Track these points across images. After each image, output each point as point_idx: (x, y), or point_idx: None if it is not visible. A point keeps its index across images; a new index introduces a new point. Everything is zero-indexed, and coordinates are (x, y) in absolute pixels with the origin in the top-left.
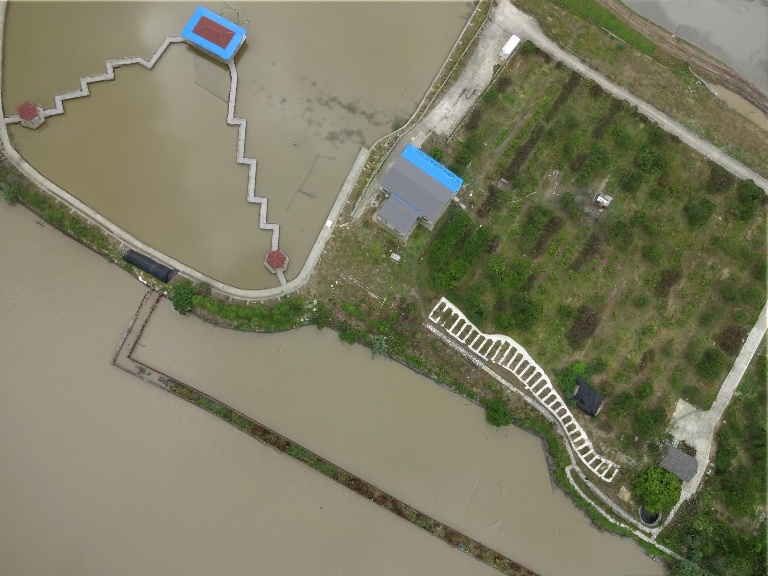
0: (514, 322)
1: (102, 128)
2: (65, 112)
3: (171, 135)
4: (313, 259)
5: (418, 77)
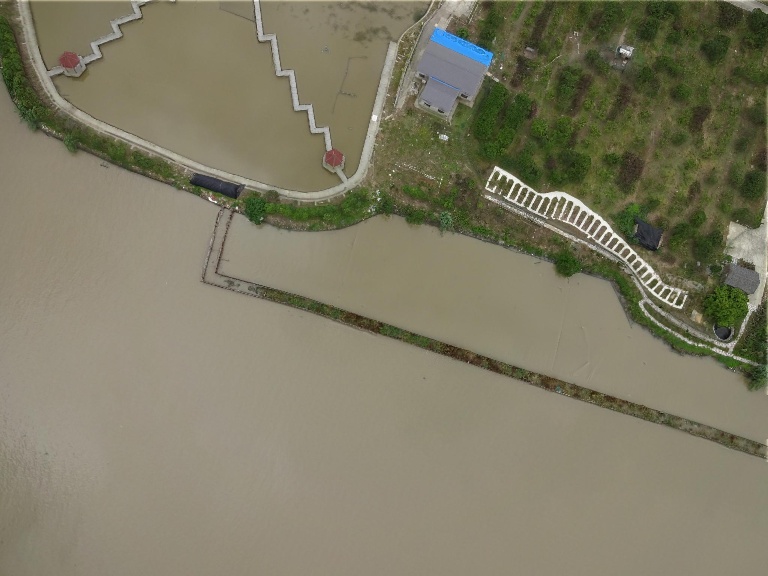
0: (567, 176)
1: (141, 66)
2: (103, 56)
3: (208, 61)
4: (367, 153)
5: None
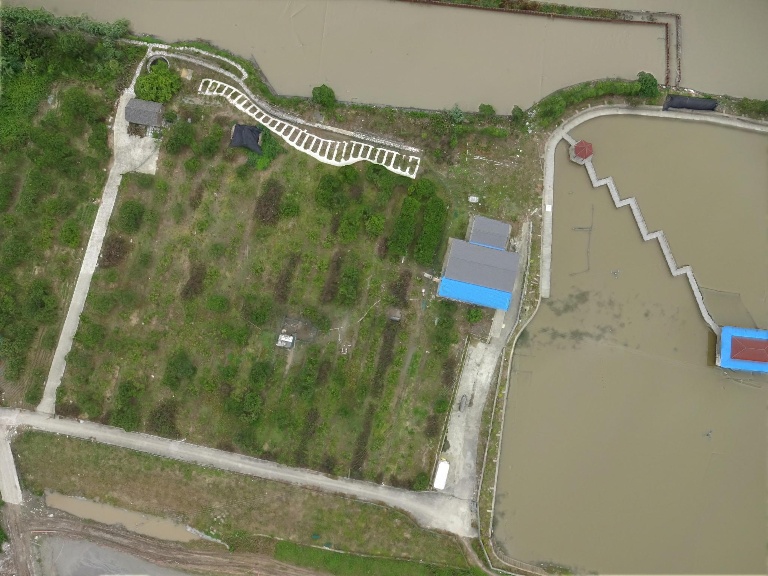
0: (340, 177)
1: None
2: None
3: (734, 233)
4: (549, 169)
5: (524, 402)
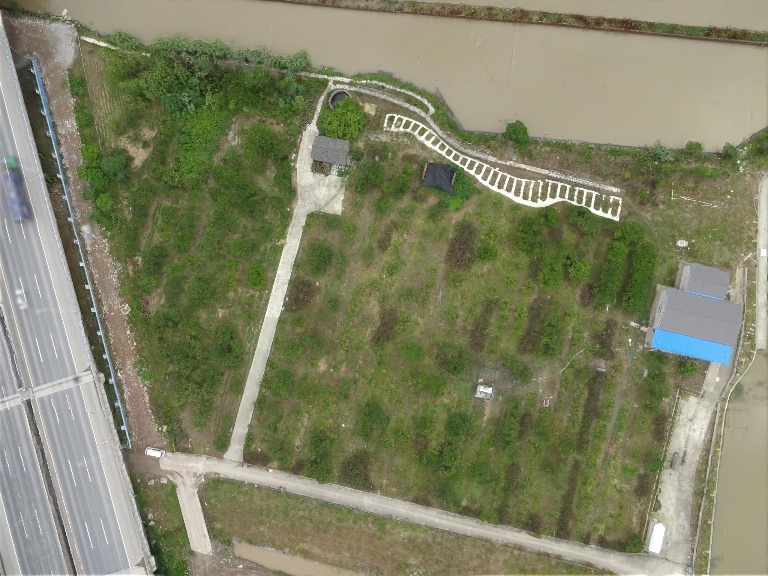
0: (541, 220)
1: None
2: None
3: None
4: (763, 210)
5: (738, 460)
